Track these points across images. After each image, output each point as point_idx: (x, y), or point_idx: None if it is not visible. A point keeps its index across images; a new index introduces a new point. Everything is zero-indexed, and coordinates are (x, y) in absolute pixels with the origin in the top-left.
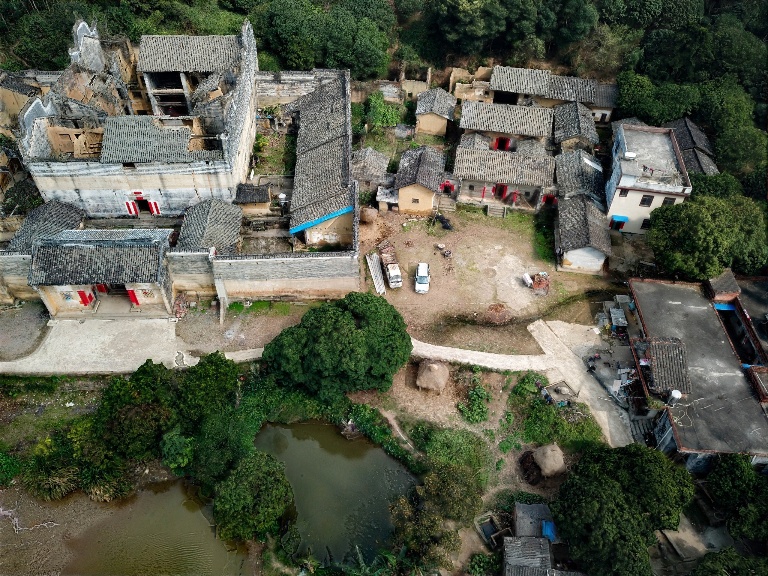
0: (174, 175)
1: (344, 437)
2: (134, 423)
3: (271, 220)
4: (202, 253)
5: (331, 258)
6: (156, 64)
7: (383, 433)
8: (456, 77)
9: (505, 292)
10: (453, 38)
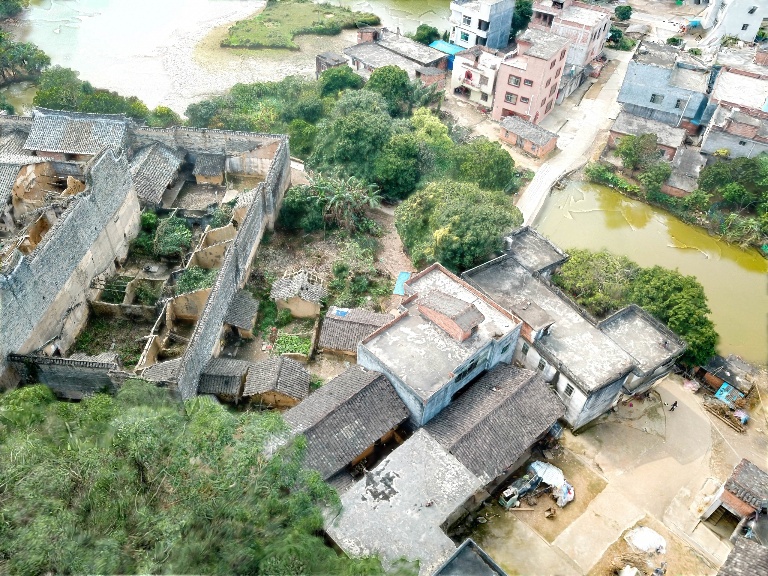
0: None
1: None
2: None
3: None
4: None
5: None
6: None
7: None
8: None
9: None
10: None
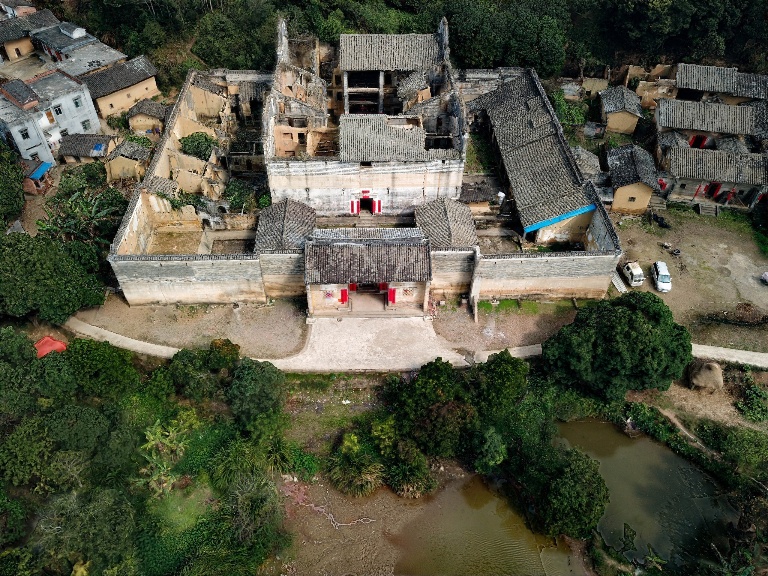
0: (407, 174)
1: (626, 435)
2: (447, 421)
3: (494, 219)
4: (466, 252)
5: (595, 257)
6: (358, 63)
7: (668, 431)
8: (631, 75)
9: (747, 291)
10: (636, 36)
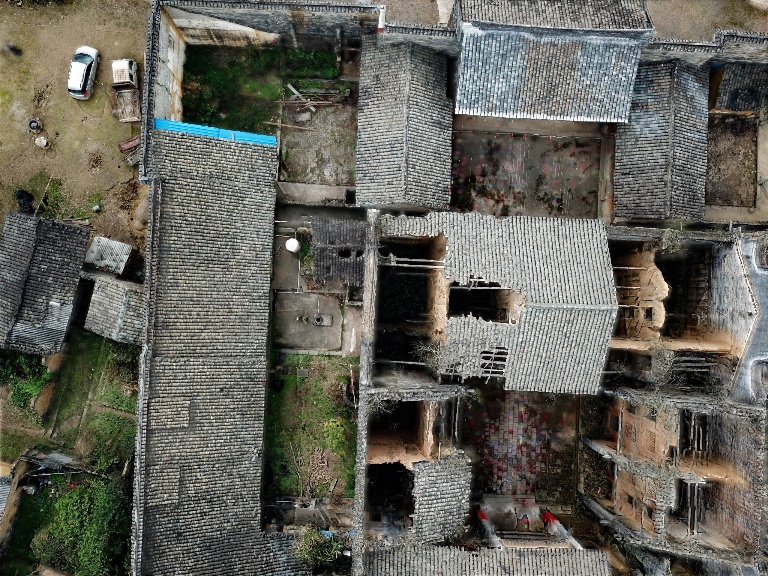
0: None
1: None
2: None
3: (313, 204)
4: None
5: None
6: (566, 572)
7: None
8: None
9: None
10: None
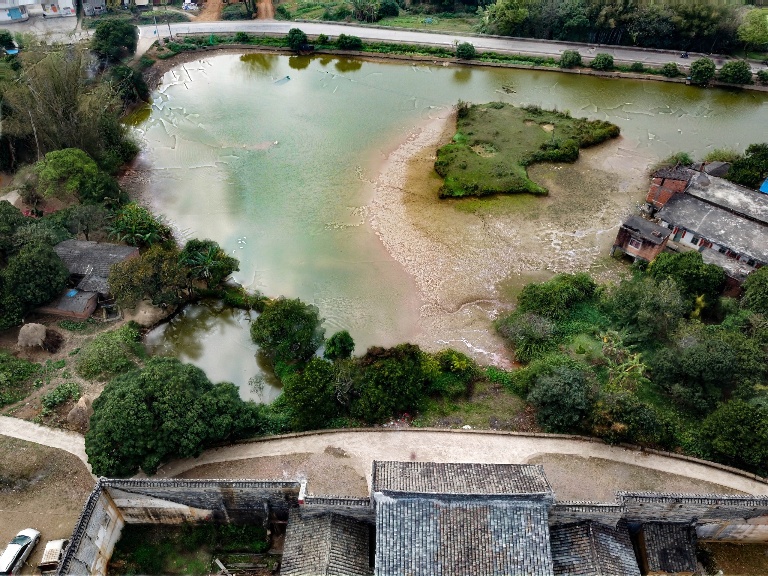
0: None
1: None
2: None
3: None
4: None
5: None
6: None
7: None
8: None
9: None
10: None
